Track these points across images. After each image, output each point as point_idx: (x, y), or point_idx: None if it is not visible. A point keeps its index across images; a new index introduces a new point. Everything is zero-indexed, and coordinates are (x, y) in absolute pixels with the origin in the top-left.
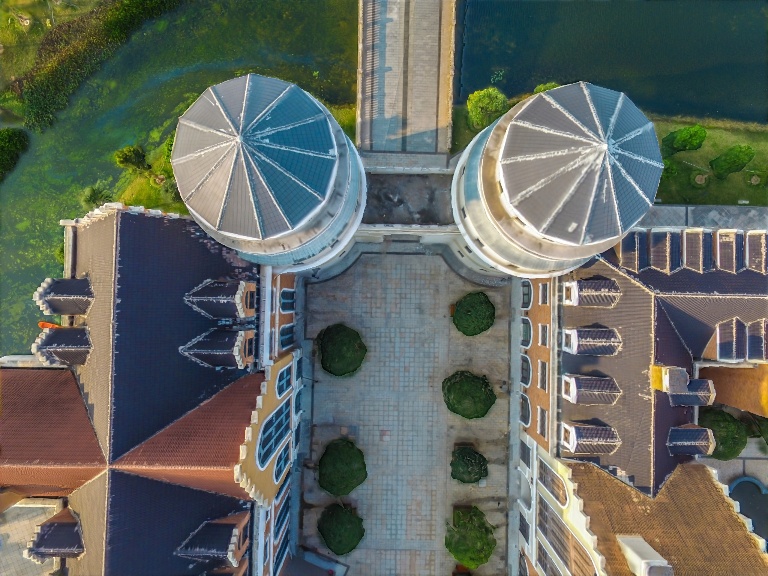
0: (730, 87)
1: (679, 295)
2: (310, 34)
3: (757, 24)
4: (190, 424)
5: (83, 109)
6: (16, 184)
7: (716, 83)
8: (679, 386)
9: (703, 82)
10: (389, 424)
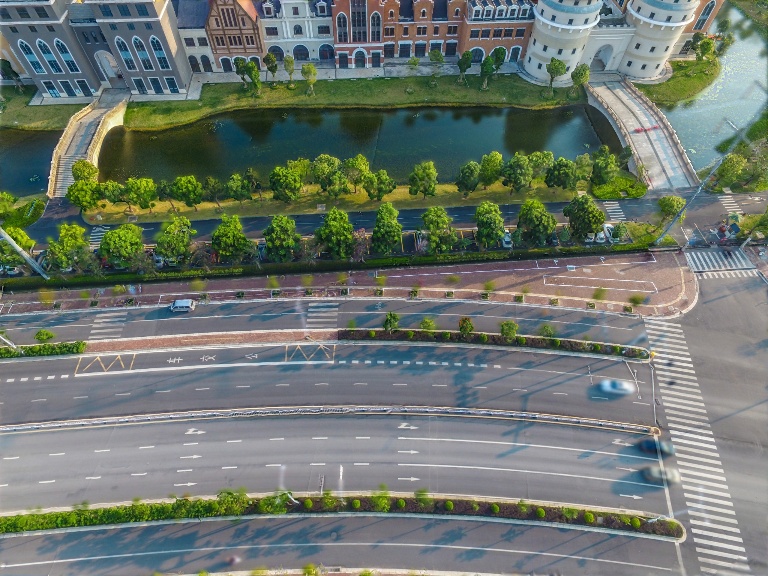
0: (448, 117)
1: None
2: (672, 123)
3: (438, 141)
4: None
5: (760, 92)
6: (767, 71)
7: (456, 118)
8: None
9: (463, 118)
10: None
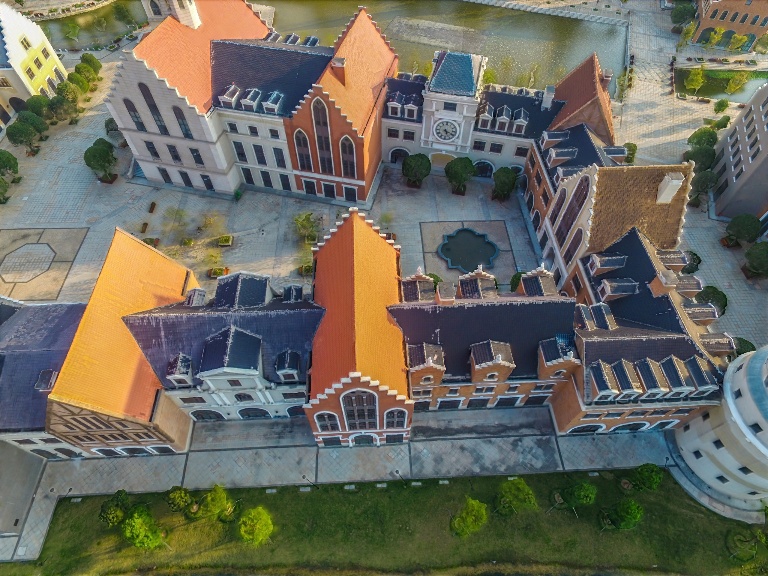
0: None
1: (671, 336)
2: None
3: None
4: None
5: None
6: None
7: None
8: (668, 274)
9: None
10: (730, 292)
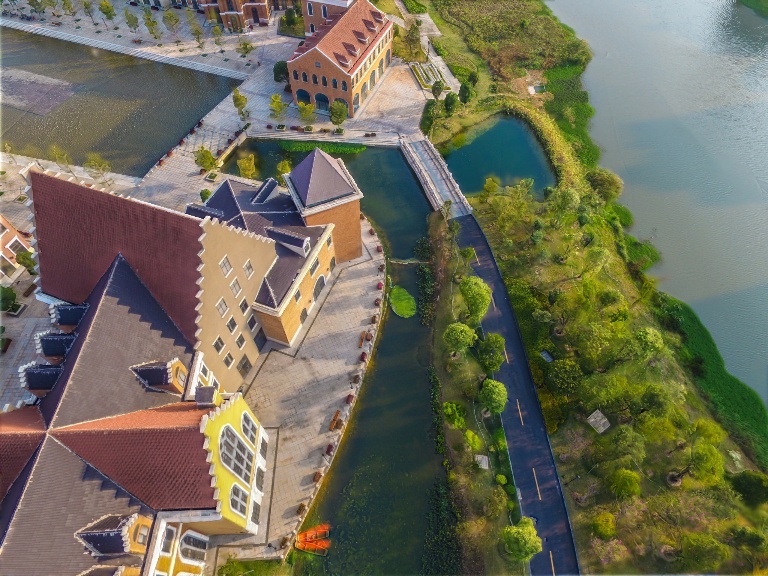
0: None
1: None
2: None
3: None
4: (8, 467)
5: None
6: None
7: None
8: None
9: None
10: None
